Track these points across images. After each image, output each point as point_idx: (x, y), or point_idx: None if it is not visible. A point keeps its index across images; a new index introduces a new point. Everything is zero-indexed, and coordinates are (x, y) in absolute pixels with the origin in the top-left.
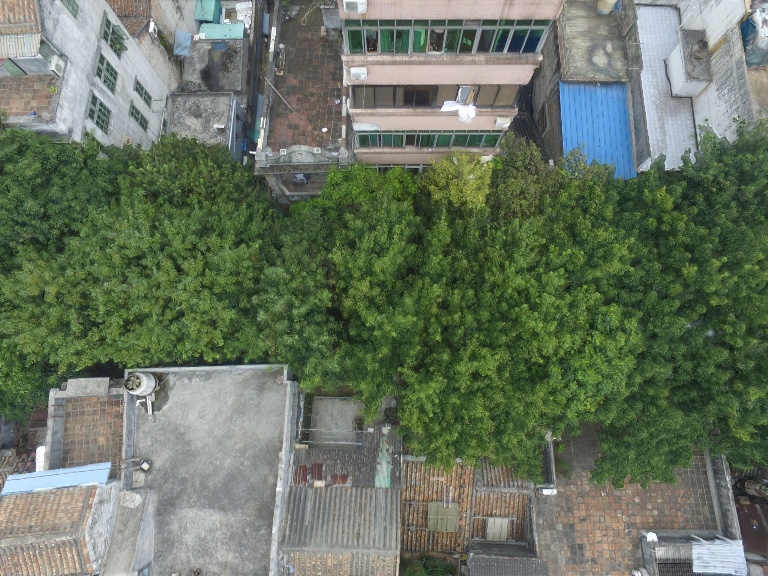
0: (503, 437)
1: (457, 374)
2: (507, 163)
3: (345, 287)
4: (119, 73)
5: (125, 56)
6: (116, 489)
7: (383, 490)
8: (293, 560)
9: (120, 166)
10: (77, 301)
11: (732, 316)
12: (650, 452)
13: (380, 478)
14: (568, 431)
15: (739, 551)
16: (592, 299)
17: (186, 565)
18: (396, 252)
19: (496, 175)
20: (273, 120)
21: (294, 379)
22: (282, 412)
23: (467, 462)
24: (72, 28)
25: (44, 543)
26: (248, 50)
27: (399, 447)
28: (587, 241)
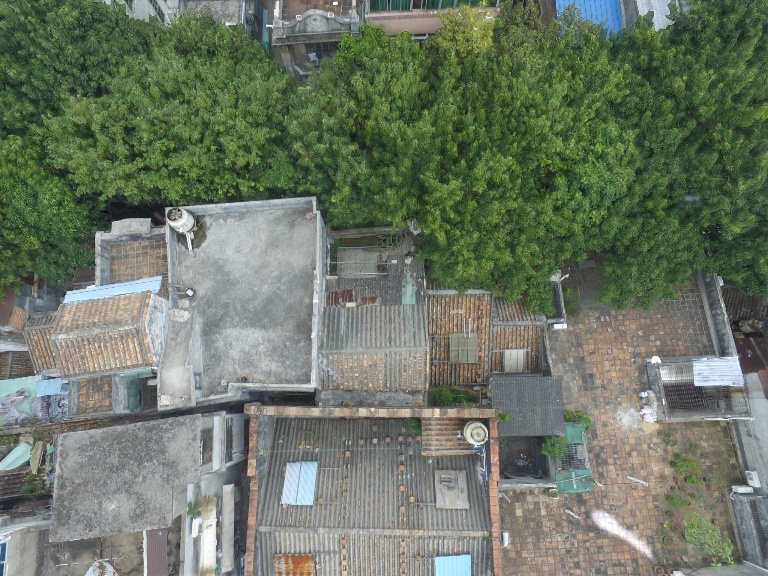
0: (517, 248)
1: (474, 181)
2: (507, 23)
3: (367, 115)
4: None
5: None
6: (166, 306)
7: (410, 306)
8: (332, 363)
9: (148, 31)
10: (121, 133)
11: (720, 125)
12: (651, 268)
13: (406, 298)
14: (574, 276)
15: (736, 366)
16: (593, 110)
17: (233, 375)
18: (412, 82)
19: (498, 35)
20: None
21: (322, 215)
22: (313, 243)
23: (486, 265)
24: None
25: (108, 334)
26: None
27: (422, 273)
28: (585, 74)
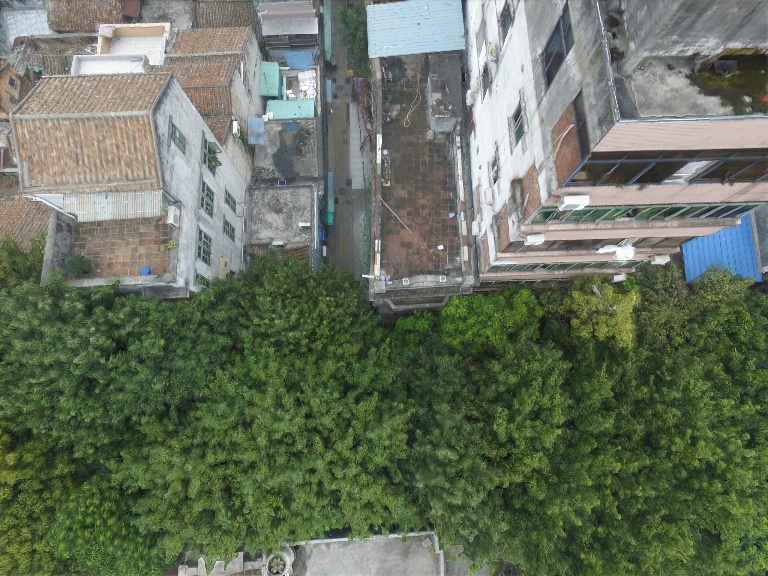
0: None
1: (641, 555)
2: (641, 282)
3: (507, 455)
4: (214, 192)
5: (218, 170)
6: None
7: None
8: None
9: (235, 310)
10: (220, 490)
11: None
12: None
13: None
14: None
15: None
16: None
17: None
18: (560, 414)
19: None
20: (384, 238)
21: None
22: None
23: None
24: (183, 167)
25: None
26: (321, 130)
27: None
28: (751, 383)
